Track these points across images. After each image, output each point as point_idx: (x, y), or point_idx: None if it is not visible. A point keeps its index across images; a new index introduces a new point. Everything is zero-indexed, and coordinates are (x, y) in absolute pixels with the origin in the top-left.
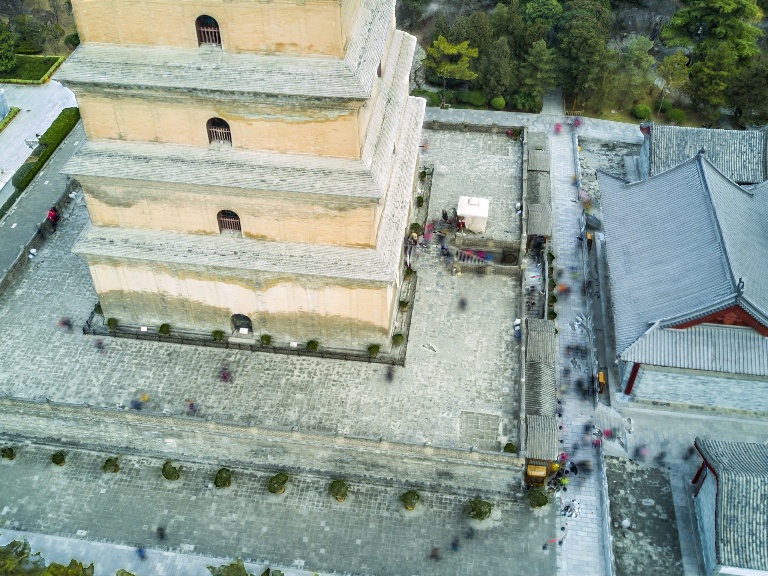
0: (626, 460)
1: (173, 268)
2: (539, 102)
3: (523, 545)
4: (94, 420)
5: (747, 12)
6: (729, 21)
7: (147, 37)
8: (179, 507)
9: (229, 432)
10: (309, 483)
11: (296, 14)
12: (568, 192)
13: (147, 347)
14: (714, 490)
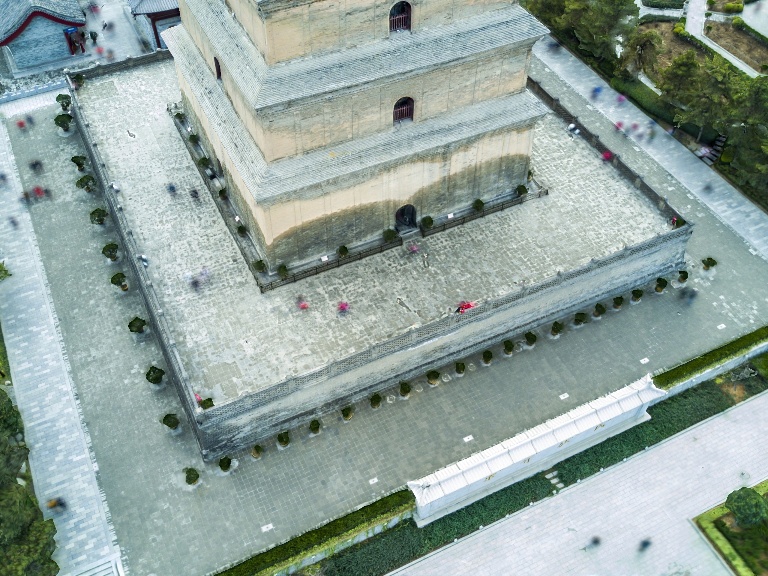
0: None
1: None
2: None
3: None
4: None
5: None
6: None
7: None
8: None
9: None
10: None
11: None
12: None
13: None
14: None
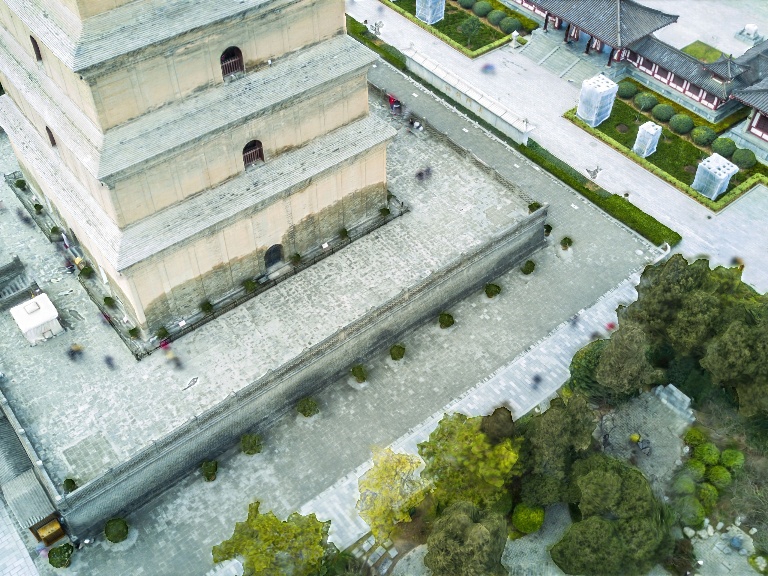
0: None
1: None
2: None
3: None
4: None
5: None
6: None
7: None
8: None
9: None
10: None
11: None
12: None
13: None
14: None
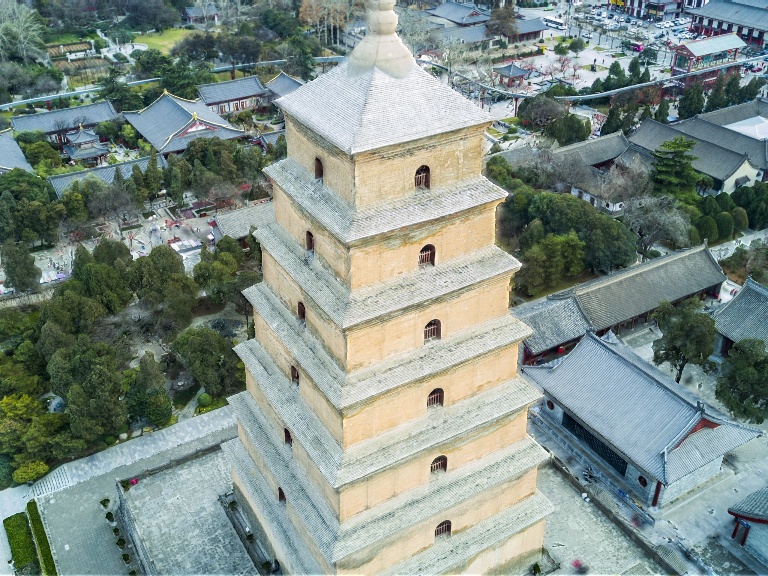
0: (693, 548)
1: None
2: None
3: None
4: None
5: None
6: None
7: (394, 422)
8: None
9: None
10: None
11: (494, 363)
12: None
13: None
14: (766, 533)
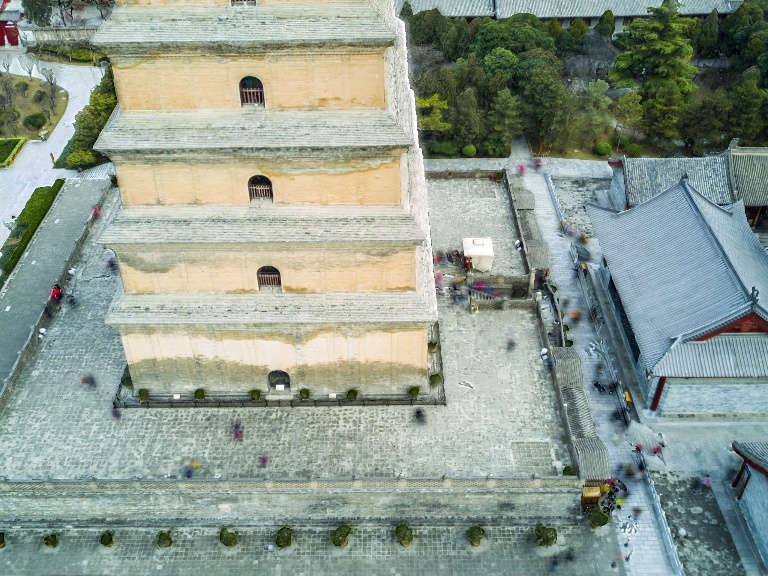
0: (666, 473)
1: (211, 330)
2: (508, 147)
3: (592, 566)
4: (144, 494)
5: (684, 52)
6: (669, 61)
7: (190, 101)
8: (243, 573)
9: (287, 489)
10: (370, 532)
11: (340, 69)
12: (553, 228)
13: (183, 414)
14: (763, 489)
